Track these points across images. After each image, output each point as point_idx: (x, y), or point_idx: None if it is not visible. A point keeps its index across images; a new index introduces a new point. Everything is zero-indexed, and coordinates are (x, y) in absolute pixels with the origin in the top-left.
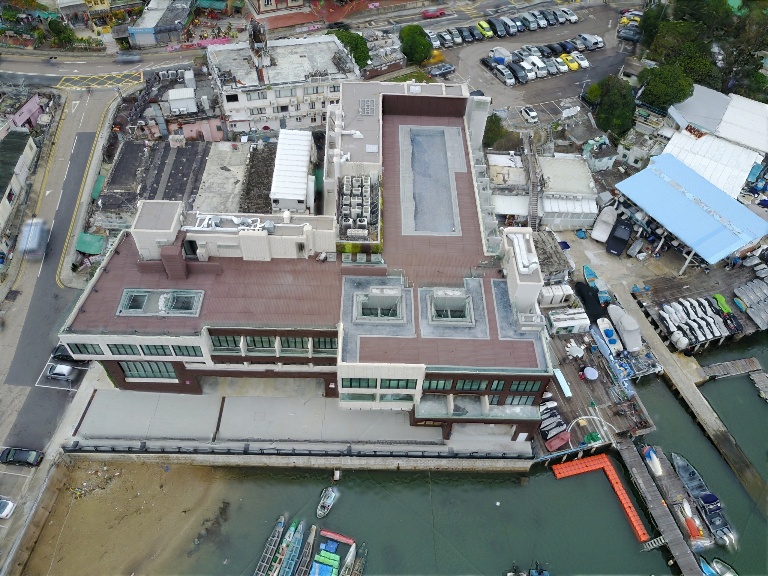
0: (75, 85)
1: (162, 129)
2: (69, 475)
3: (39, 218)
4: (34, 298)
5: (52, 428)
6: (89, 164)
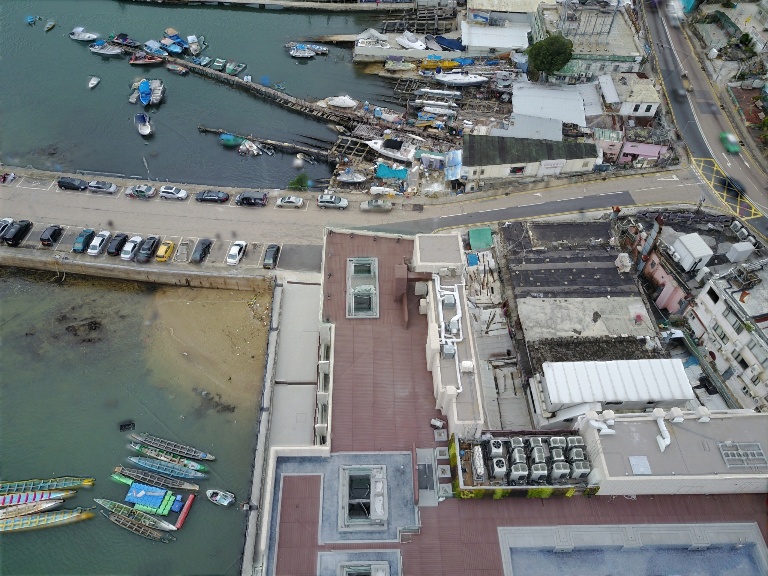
0: (703, 170)
1: (646, 248)
2: (267, 293)
3: (505, 198)
4: (416, 221)
5: (296, 268)
6: (586, 211)
